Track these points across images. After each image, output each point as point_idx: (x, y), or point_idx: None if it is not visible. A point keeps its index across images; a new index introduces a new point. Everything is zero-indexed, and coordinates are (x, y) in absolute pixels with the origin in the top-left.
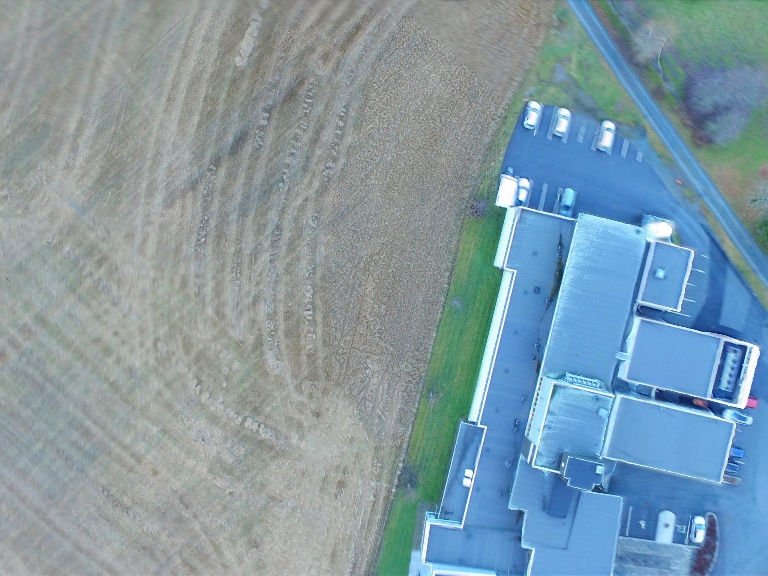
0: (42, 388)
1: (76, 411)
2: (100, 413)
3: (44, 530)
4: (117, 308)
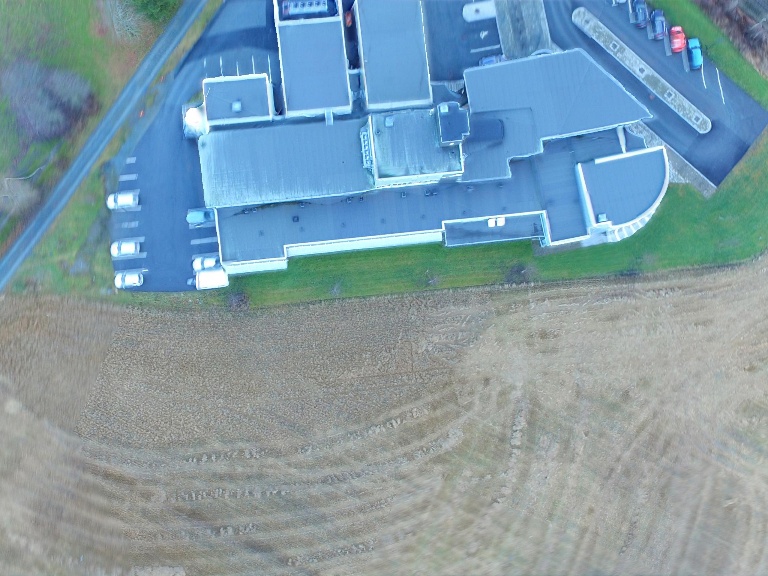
0: None
1: None
2: None
3: None
4: None
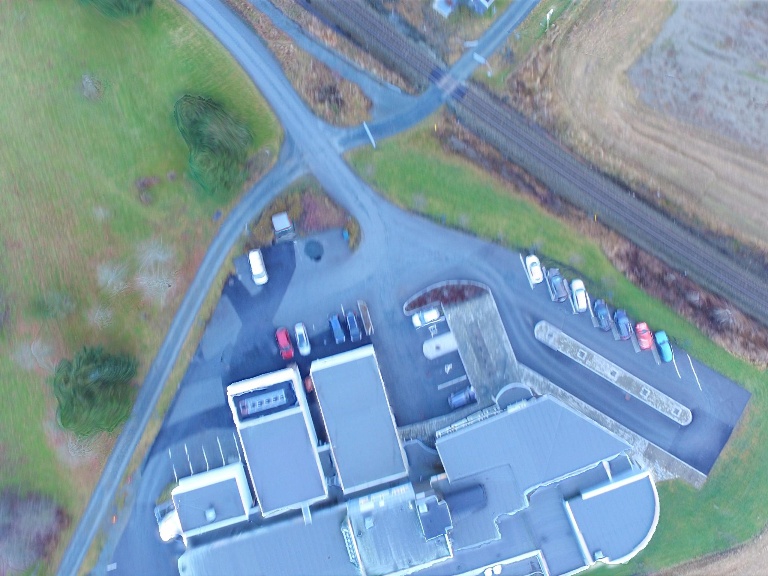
0: None
1: None
2: None
3: None
4: None
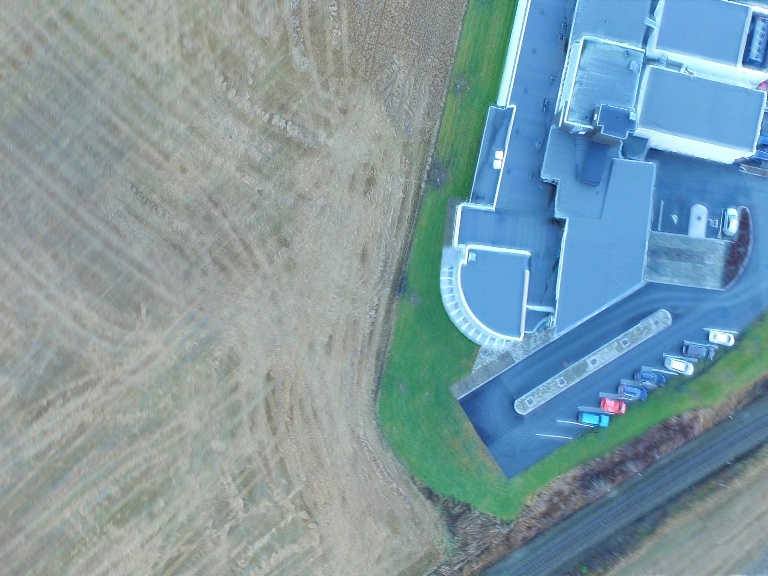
0: (69, 83)
1: (103, 107)
2: (127, 110)
3: (73, 227)
4: (142, 4)
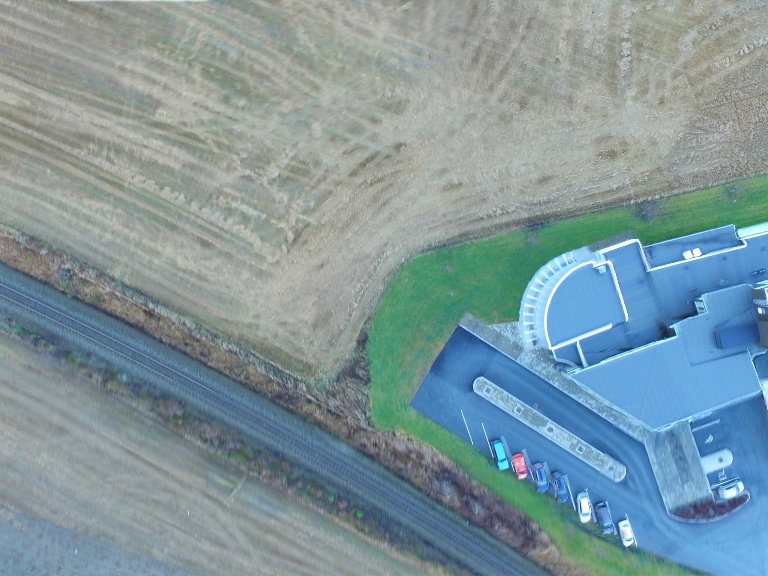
0: None
1: None
2: None
3: None
4: None
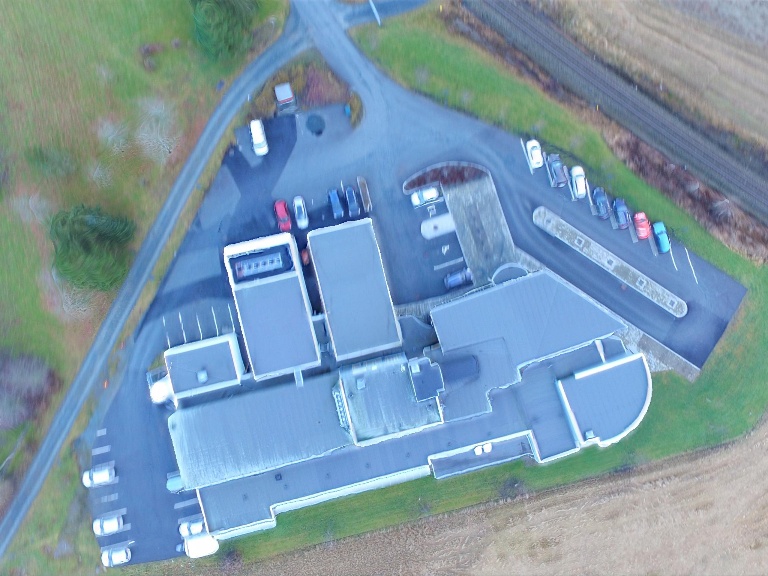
0: None
1: None
2: None
3: None
4: None
